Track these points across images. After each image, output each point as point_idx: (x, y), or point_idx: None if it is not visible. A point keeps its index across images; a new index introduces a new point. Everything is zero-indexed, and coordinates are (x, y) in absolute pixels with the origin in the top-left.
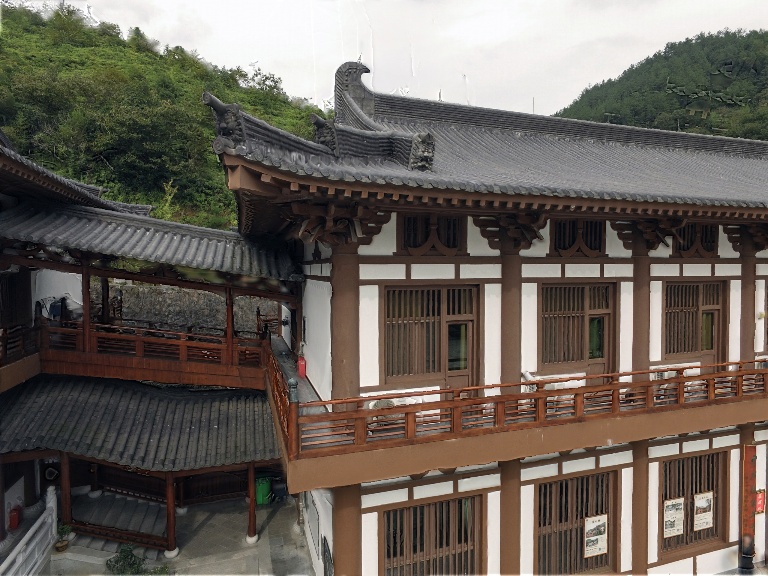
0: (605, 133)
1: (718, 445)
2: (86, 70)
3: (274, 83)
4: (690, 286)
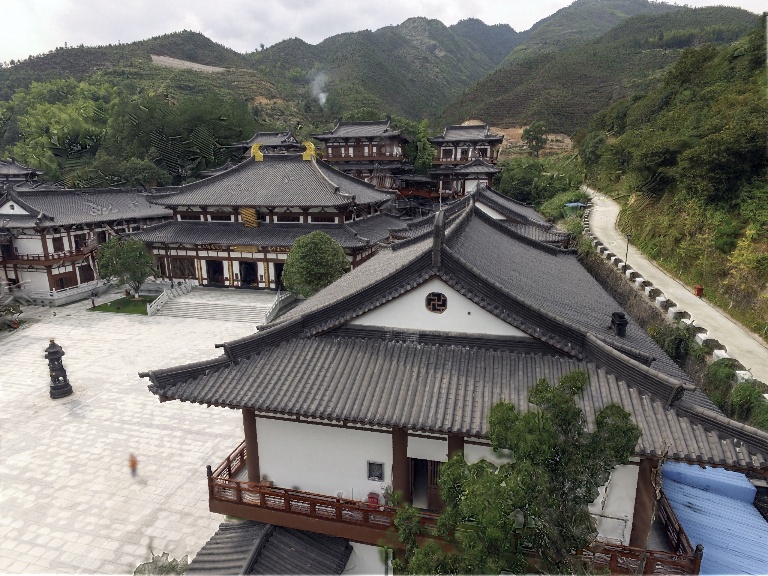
0: None
1: None
2: None
3: None
4: None
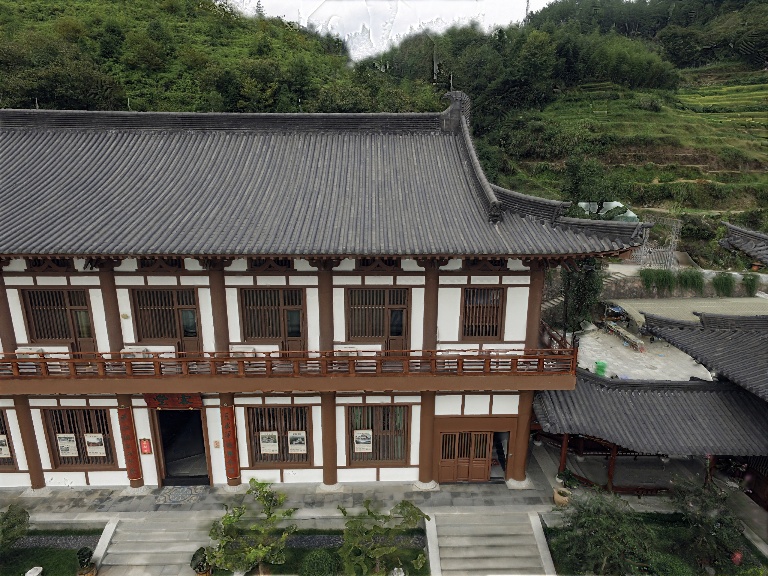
0: (206, 123)
1: (96, 404)
2: (63, 17)
3: (229, 9)
4: (56, 291)
